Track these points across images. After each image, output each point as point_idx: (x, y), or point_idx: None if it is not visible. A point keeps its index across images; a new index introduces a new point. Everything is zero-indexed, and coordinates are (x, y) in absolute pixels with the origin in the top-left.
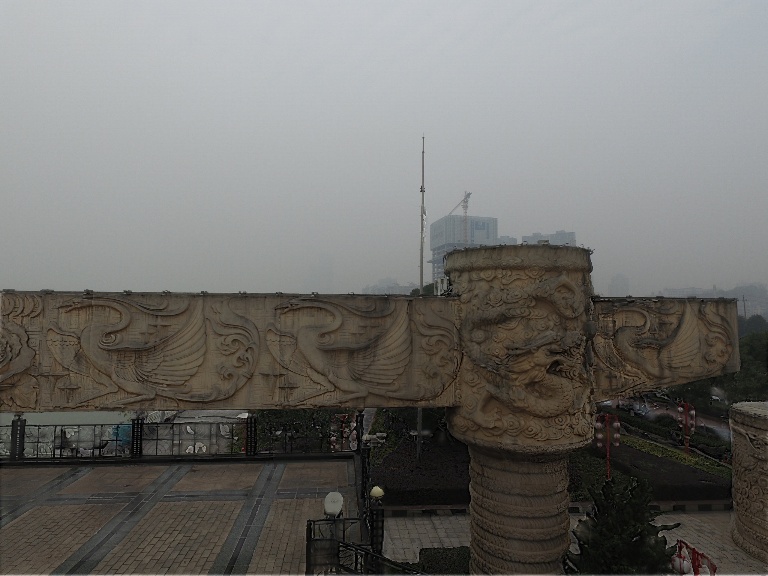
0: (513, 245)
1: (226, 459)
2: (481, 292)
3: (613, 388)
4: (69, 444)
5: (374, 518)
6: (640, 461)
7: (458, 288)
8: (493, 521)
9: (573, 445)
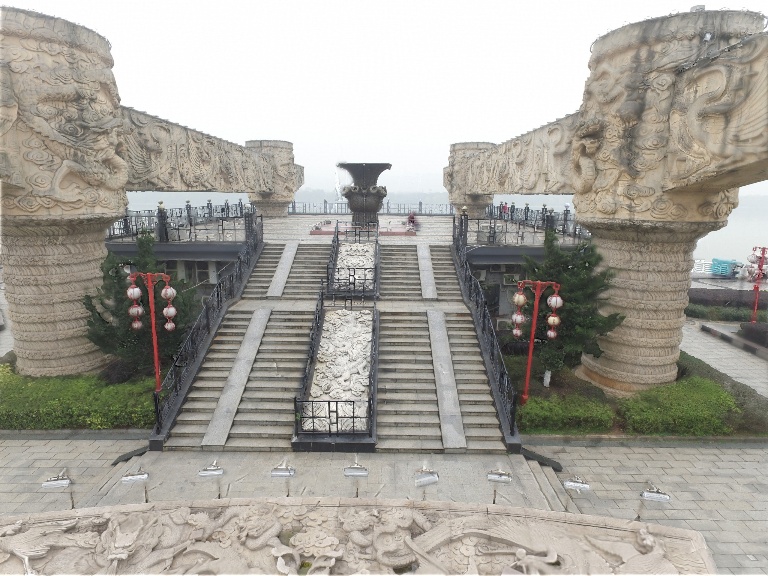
0: None
1: None
2: None
3: None
4: None
5: None
6: None
7: None
8: None
9: (595, 219)
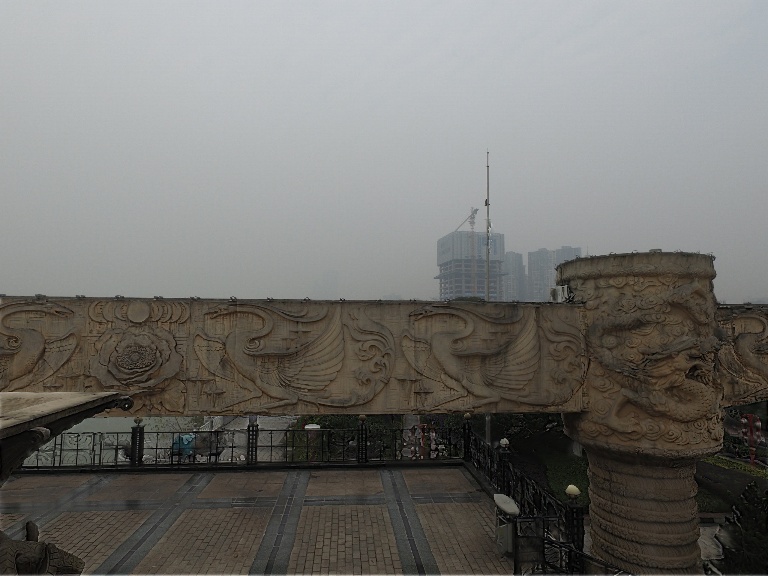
0: (645, 253)
1: (339, 466)
2: (611, 299)
3: (735, 394)
4: (187, 450)
5: (574, 516)
6: (710, 473)
7: (582, 295)
8: (625, 527)
9: (711, 449)
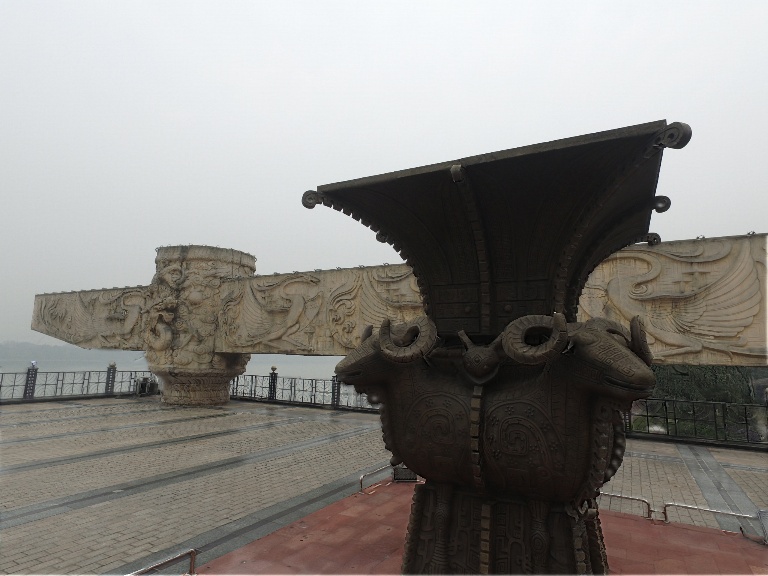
0: None
1: (744, 447)
2: None
3: None
4: None
5: None
6: None
7: None
8: None
9: None
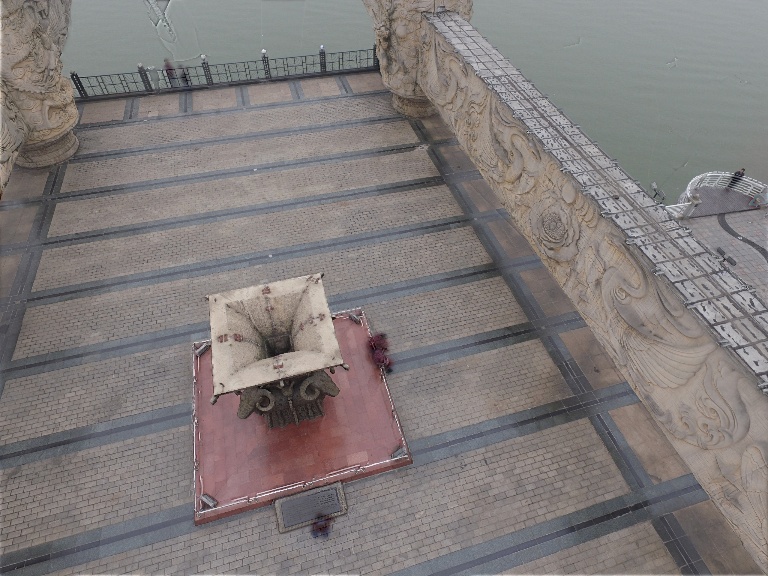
0: None
1: None
2: None
3: None
4: None
5: None
6: None
7: None
8: None
9: None
